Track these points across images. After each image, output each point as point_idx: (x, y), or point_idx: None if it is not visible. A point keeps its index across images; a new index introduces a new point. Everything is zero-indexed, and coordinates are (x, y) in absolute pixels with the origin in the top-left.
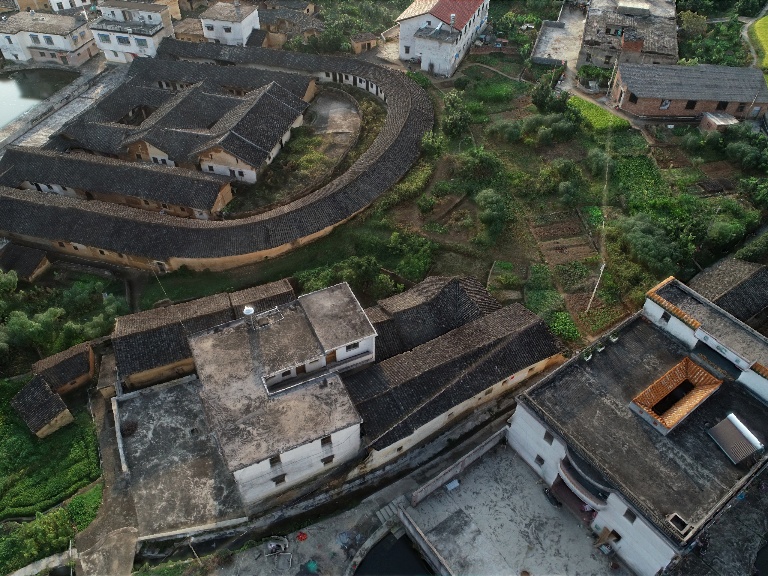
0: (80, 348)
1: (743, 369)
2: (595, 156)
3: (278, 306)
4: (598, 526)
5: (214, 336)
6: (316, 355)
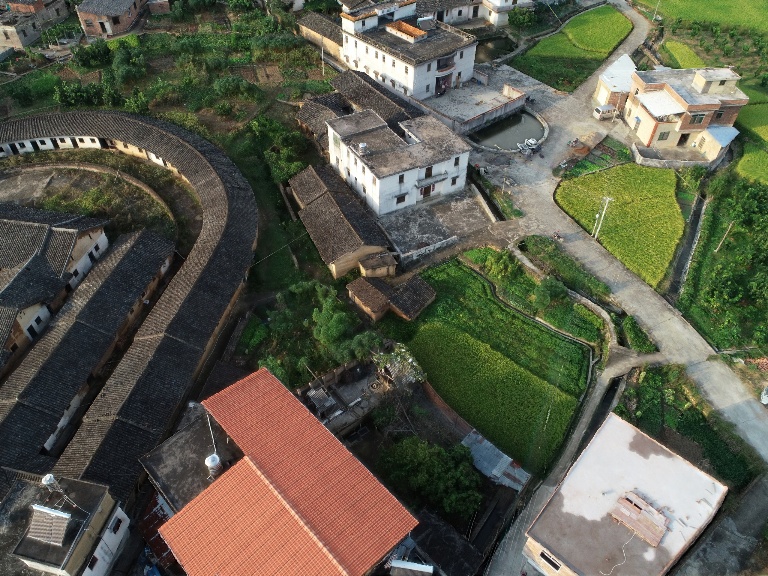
0: (357, 286)
1: (397, 10)
2: (183, 45)
3: (348, 146)
4: (454, 81)
5: (377, 168)
6: (388, 130)
